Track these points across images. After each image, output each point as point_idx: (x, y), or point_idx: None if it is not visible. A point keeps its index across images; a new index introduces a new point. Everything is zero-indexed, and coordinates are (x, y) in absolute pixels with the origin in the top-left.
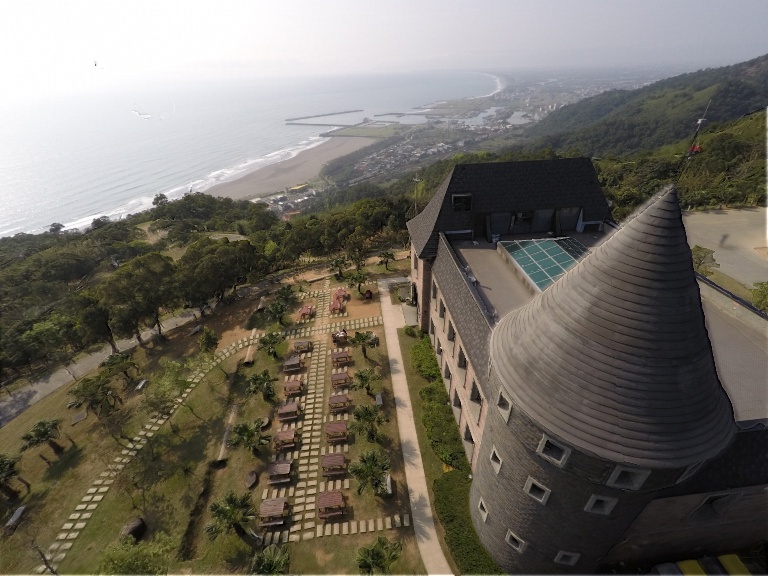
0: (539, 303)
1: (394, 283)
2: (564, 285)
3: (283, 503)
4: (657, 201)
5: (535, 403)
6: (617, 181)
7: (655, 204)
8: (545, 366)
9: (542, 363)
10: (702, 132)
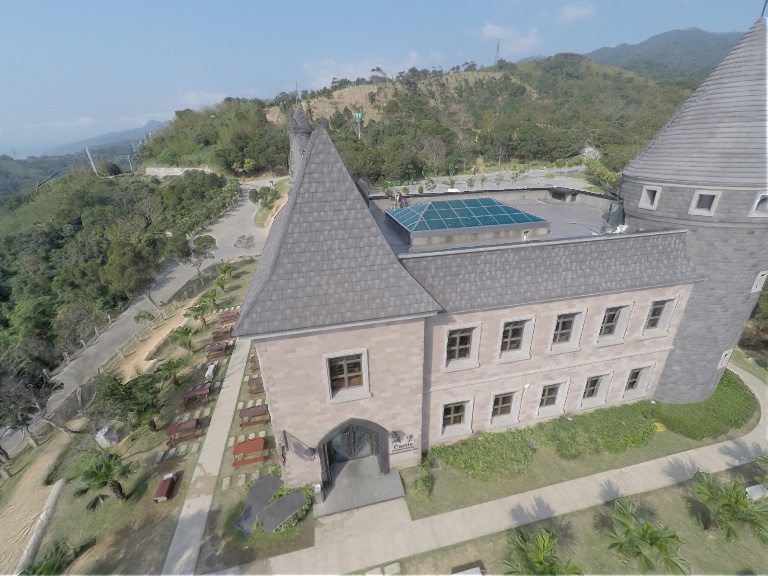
0: (765, 123)
1: (202, 553)
2: (767, 98)
3: None
4: (764, 23)
5: None
6: (5, 269)
7: (766, 25)
8: None
9: None
10: (6, 207)
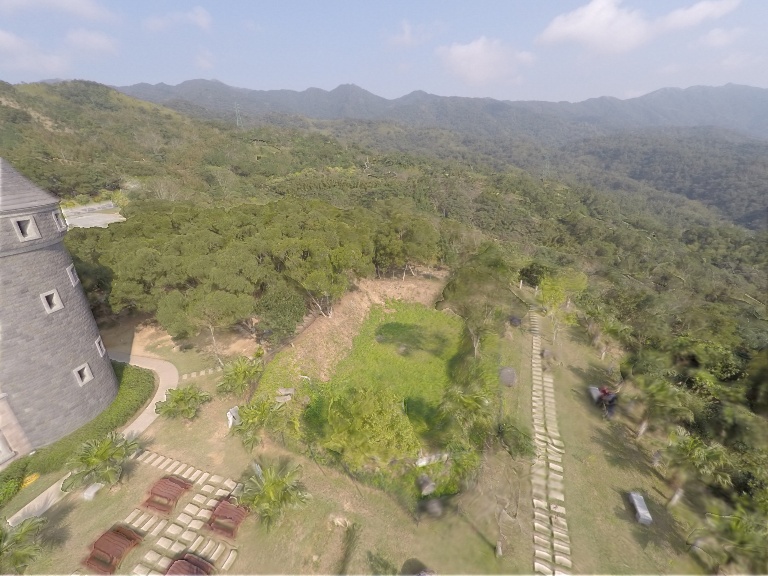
0: None
1: None
2: None
3: (215, 512)
4: None
5: (36, 196)
6: None
7: None
8: (4, 179)
9: (1, 179)
10: None
